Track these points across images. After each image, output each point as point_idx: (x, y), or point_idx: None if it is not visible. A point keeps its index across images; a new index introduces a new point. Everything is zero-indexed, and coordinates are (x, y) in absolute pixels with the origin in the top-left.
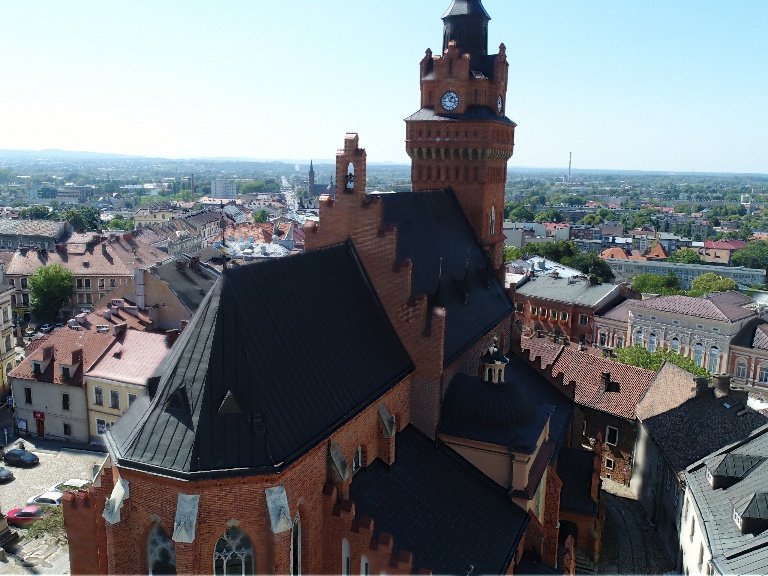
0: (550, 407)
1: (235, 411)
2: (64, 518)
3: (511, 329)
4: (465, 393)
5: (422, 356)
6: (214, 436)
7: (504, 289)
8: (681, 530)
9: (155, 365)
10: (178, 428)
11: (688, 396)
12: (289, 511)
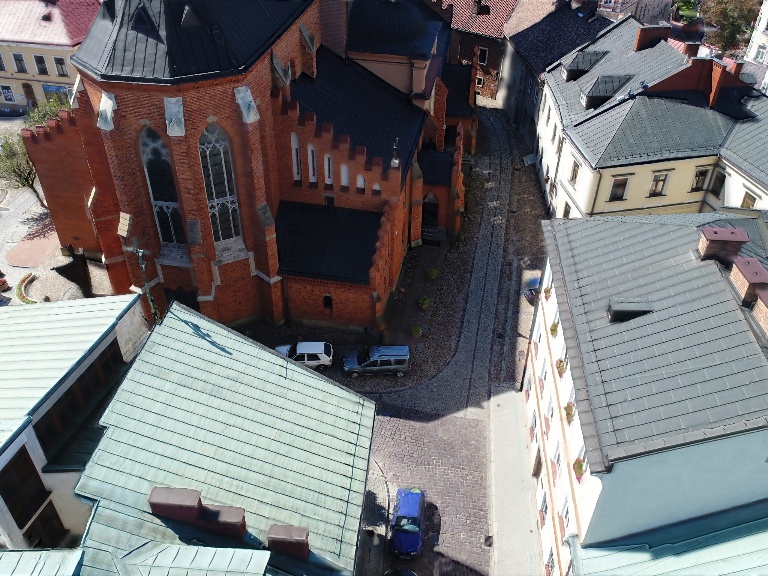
0: (438, 23)
1: (195, 24)
2: (28, 154)
3: None
4: (367, 12)
5: None
6: (183, 47)
7: None
8: (539, 122)
9: (32, 20)
10: (148, 43)
11: (549, 11)
12: (255, 106)
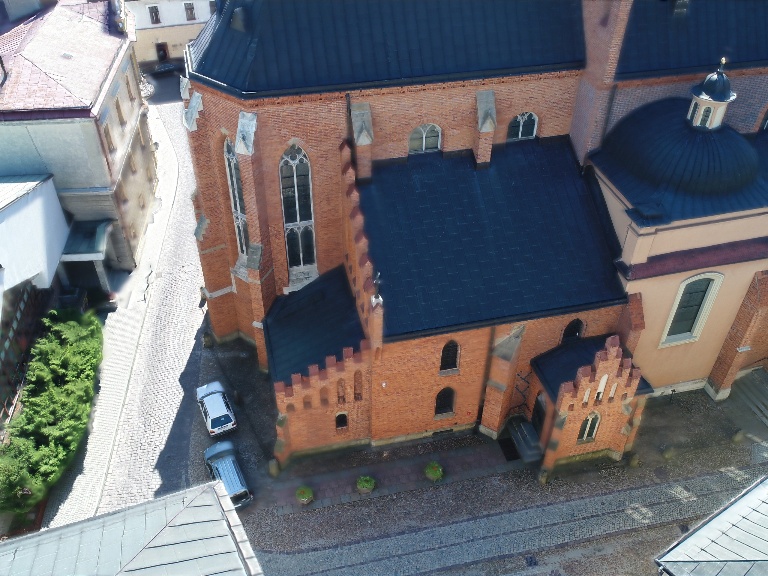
0: None
1: (242, 30)
2: None
3: None
4: (647, 123)
5: (594, 52)
6: (221, 47)
7: None
8: None
9: None
10: None
11: None
12: (253, 139)
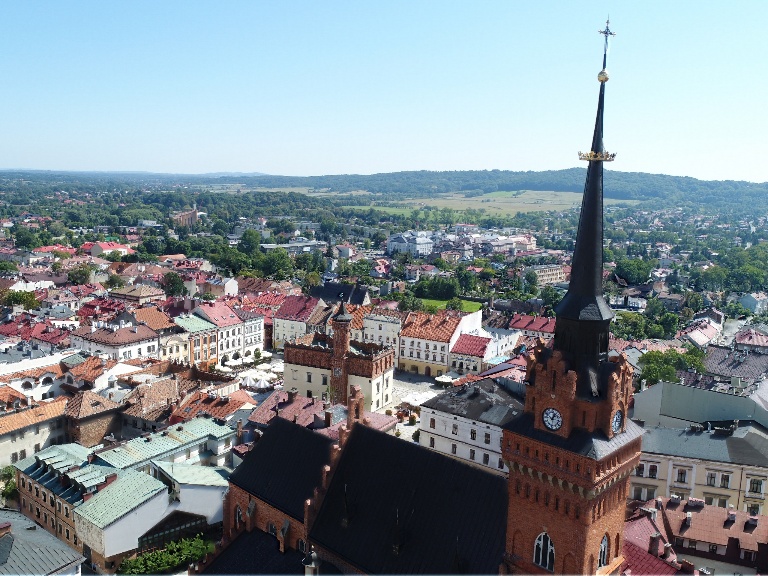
0: None
1: None
2: None
3: None
4: None
5: None
6: None
7: None
8: None
9: None
10: None
11: None
12: (225, 495)
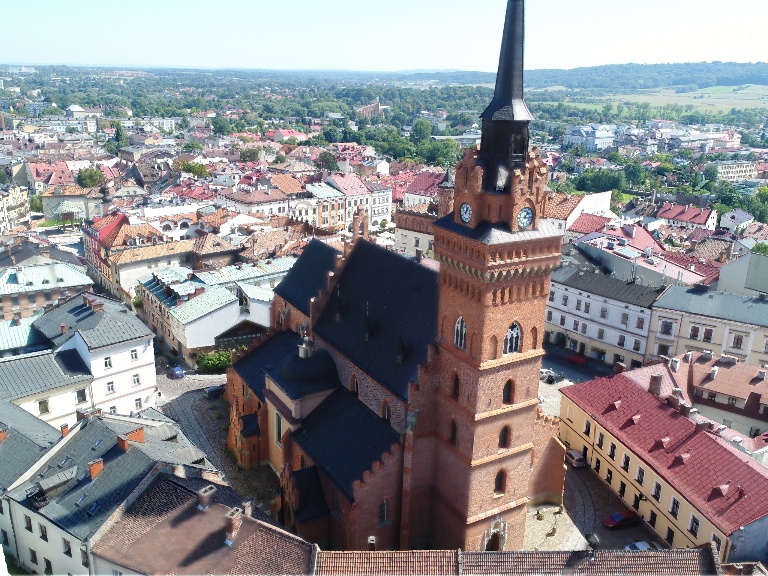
0: (293, 395)
1: None
2: None
3: (406, 419)
4: None
5: None
6: None
7: (418, 385)
8: None
9: None
10: None
11: None
12: (271, 302)
